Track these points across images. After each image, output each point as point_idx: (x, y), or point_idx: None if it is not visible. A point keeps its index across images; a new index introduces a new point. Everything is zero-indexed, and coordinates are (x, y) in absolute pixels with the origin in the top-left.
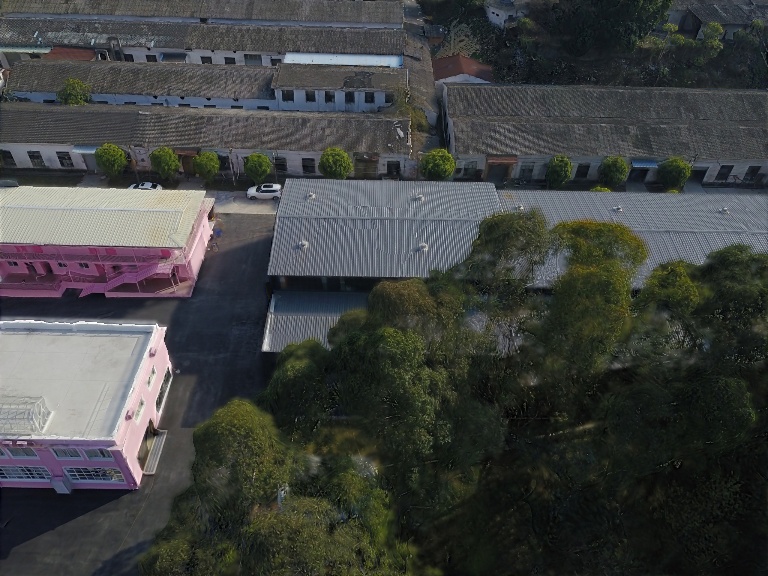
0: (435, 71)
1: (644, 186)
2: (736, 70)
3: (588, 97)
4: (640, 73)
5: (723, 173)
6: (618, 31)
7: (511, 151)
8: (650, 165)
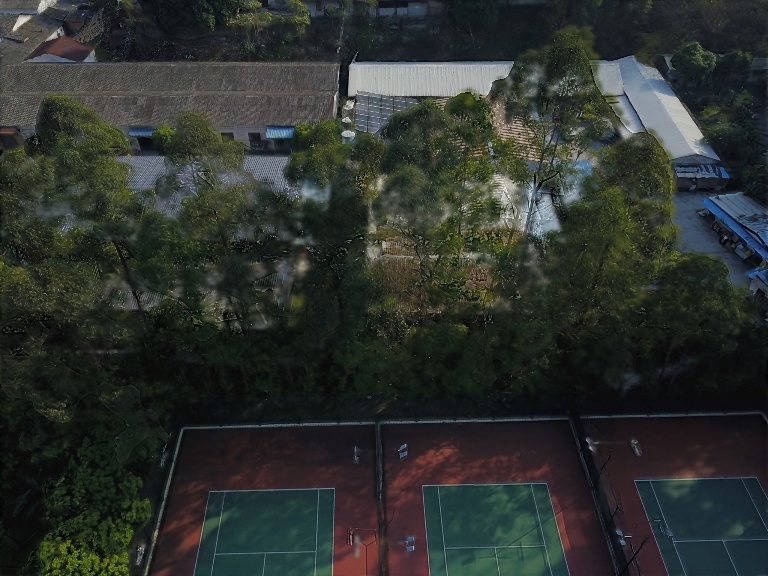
0: (32, 52)
1: (157, 154)
2: (332, 45)
3: (138, 72)
4: (239, 50)
5: (227, 140)
6: (192, 9)
7: (13, 123)
8: (145, 133)
